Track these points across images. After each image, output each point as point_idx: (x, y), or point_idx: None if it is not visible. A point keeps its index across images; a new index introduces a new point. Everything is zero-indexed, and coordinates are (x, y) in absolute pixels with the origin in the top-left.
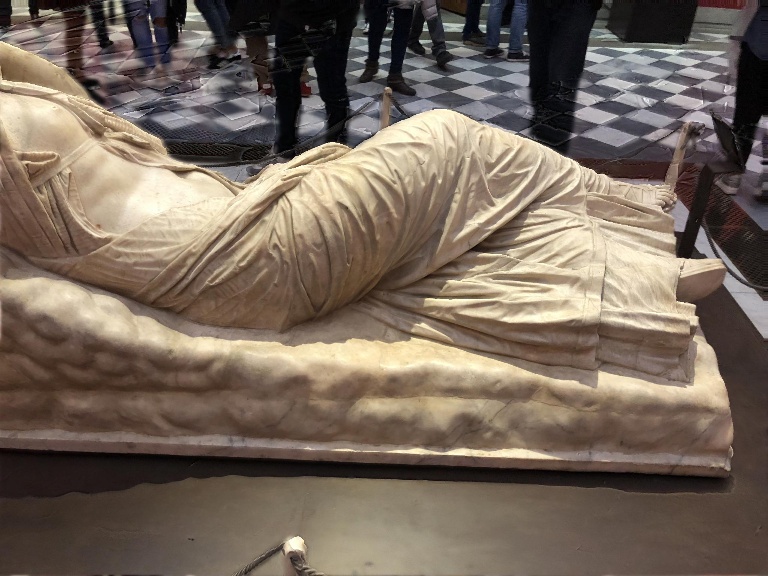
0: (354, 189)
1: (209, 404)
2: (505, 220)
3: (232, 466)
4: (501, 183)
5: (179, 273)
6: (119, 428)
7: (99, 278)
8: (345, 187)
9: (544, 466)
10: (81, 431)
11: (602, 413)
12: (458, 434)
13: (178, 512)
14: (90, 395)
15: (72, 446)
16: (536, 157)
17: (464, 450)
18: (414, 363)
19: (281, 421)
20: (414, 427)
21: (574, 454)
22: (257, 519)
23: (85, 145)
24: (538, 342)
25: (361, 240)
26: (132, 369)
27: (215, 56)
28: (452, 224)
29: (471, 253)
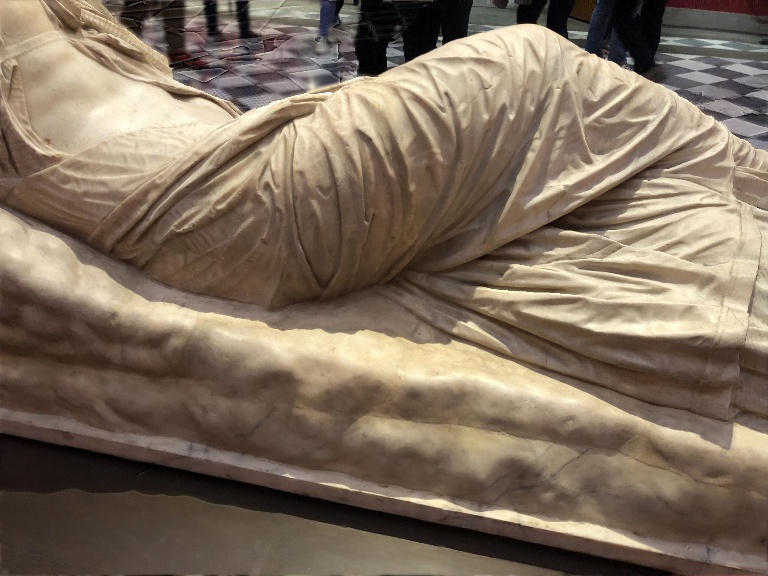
0: (383, 114)
1: (164, 395)
2: (606, 185)
3: (190, 484)
4: (605, 133)
5: (138, 211)
6: (57, 411)
7: (45, 210)
8: (371, 111)
9: (631, 557)
10: (13, 408)
11: (735, 490)
12: (502, 488)
13: (101, 536)
14: (21, 362)
15: (1, 426)
16: (662, 103)
17: (509, 513)
18: (447, 374)
19: (253, 431)
20: (438, 468)
21: (681, 547)
22: (199, 565)
23: (45, 36)
24: (639, 366)
25: (387, 189)
26: (66, 333)
27: (295, 19)
28: (525, 182)
29: (550, 229)
